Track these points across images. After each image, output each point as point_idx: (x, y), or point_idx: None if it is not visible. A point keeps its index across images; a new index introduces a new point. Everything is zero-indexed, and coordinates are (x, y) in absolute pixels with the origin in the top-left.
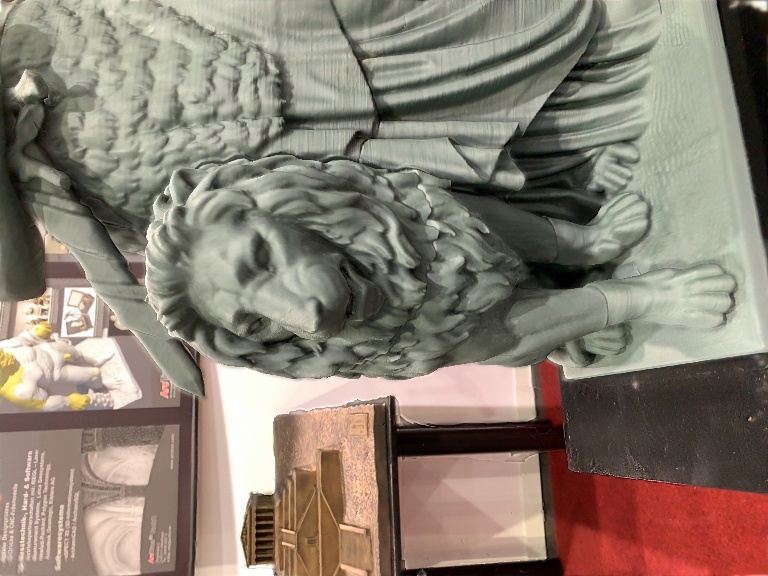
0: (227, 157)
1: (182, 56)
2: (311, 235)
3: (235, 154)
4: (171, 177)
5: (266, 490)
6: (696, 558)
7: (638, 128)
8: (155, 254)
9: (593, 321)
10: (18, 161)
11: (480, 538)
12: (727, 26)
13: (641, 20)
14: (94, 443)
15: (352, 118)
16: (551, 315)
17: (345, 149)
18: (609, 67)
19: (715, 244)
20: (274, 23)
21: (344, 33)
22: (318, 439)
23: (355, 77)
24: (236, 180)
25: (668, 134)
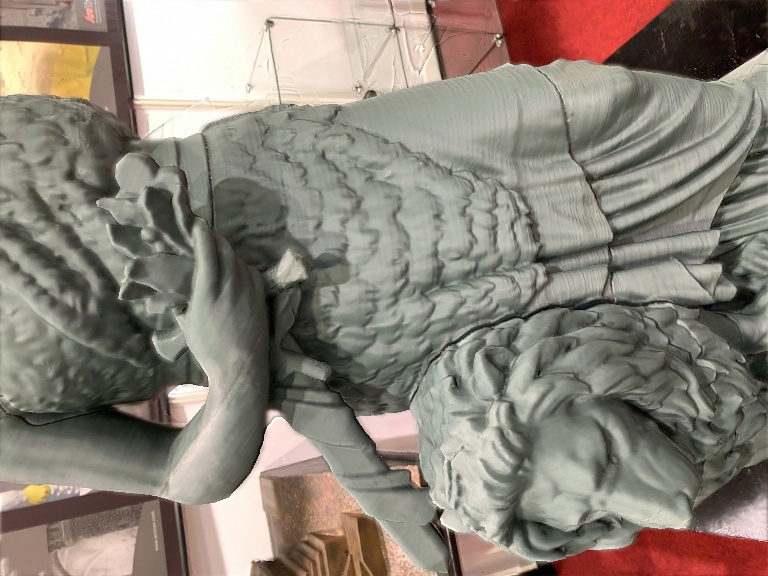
0: (497, 318)
1: (435, 205)
2: (628, 407)
3: (506, 314)
4: (477, 363)
5: (260, 552)
6: (709, 556)
7: None
8: (497, 466)
9: None
10: (278, 360)
11: (474, 557)
12: None
13: None
14: (62, 538)
15: (590, 249)
16: None
17: (603, 290)
18: (761, 158)
19: None
20: (511, 154)
21: (572, 157)
22: (342, 502)
23: (590, 205)
24: (554, 359)
25: None
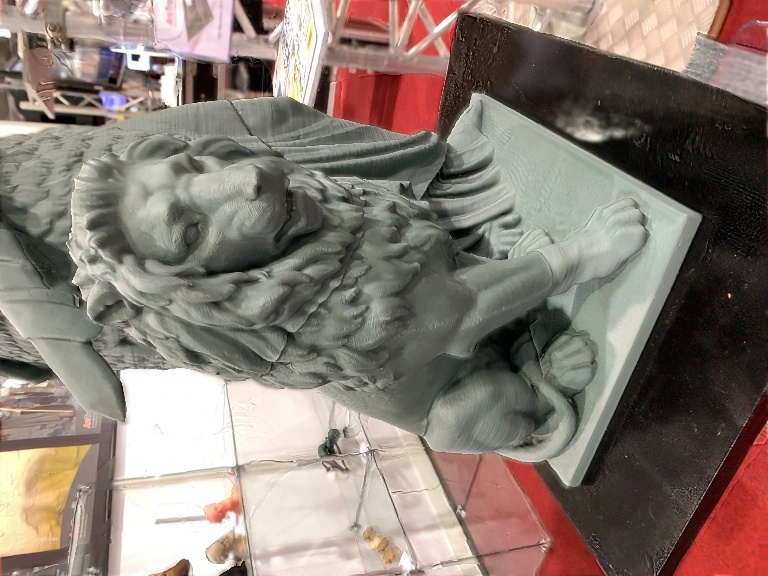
0: None
1: (117, 135)
2: None
3: None
4: None
5: None
6: None
7: (509, 200)
8: (86, 173)
9: (538, 272)
10: None
11: None
12: (533, 117)
13: (477, 145)
14: None
15: None
16: (496, 268)
17: None
18: (468, 176)
19: (604, 201)
20: (195, 129)
21: None
22: None
23: None
24: None
25: (531, 184)
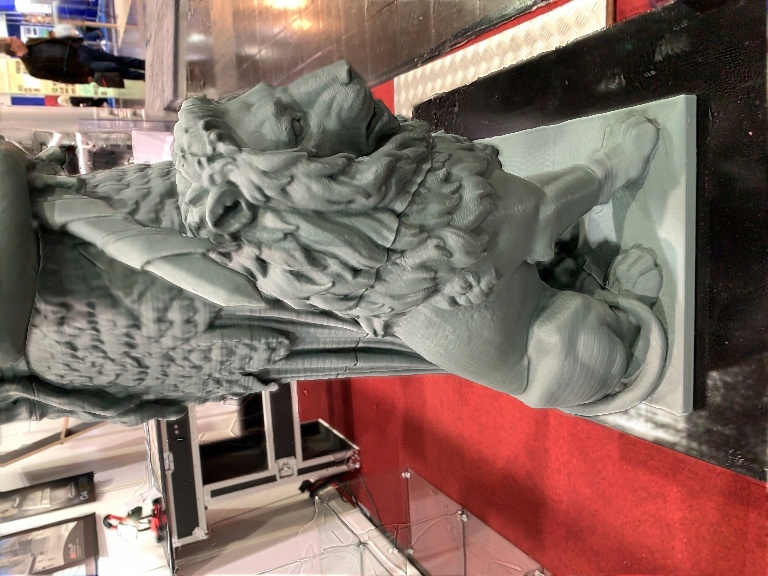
0: None
1: None
2: None
3: None
4: None
5: None
6: None
7: None
8: (189, 104)
9: (583, 173)
10: None
11: None
12: None
13: None
14: None
15: None
16: None
17: None
18: None
19: None
20: None
21: None
22: None
23: None
24: None
25: (532, 172)
